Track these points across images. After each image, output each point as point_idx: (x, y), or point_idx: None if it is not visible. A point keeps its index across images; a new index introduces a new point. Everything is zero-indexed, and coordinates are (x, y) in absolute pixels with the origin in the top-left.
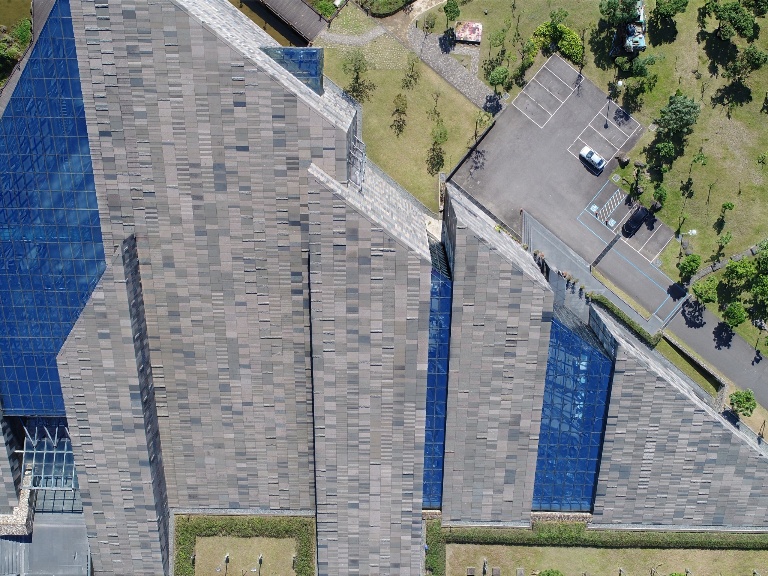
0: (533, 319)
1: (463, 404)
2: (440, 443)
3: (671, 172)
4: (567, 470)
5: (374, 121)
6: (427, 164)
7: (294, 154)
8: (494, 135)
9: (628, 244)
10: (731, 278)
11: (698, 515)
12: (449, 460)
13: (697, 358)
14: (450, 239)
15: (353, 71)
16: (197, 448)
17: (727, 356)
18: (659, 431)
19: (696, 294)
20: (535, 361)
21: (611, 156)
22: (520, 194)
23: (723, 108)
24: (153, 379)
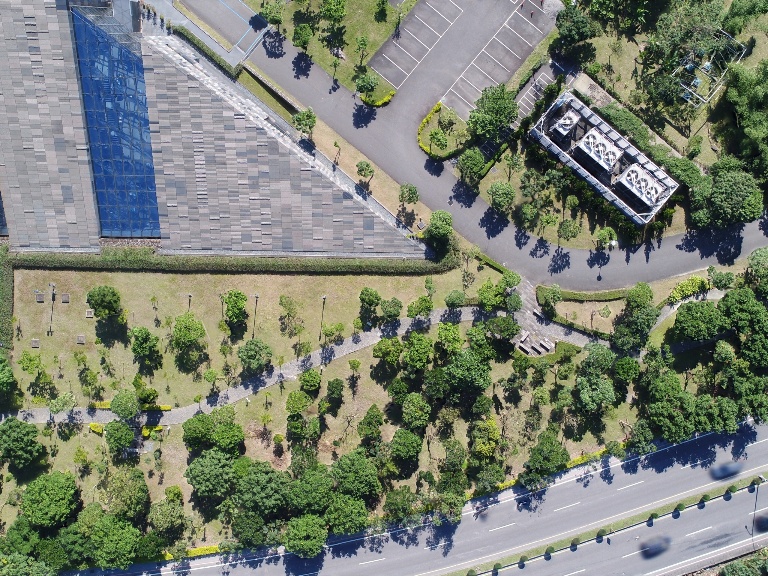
0: (48, 7)
1: (1, 108)
2: None
3: None
4: (128, 189)
5: None
6: None
7: None
8: None
9: None
10: (299, 0)
11: (266, 239)
12: (2, 175)
13: (276, 88)
14: None
15: None
16: None
17: (305, 85)
18: (204, 139)
19: (264, 16)
20: (61, 57)
21: None
22: None
23: None
24: None
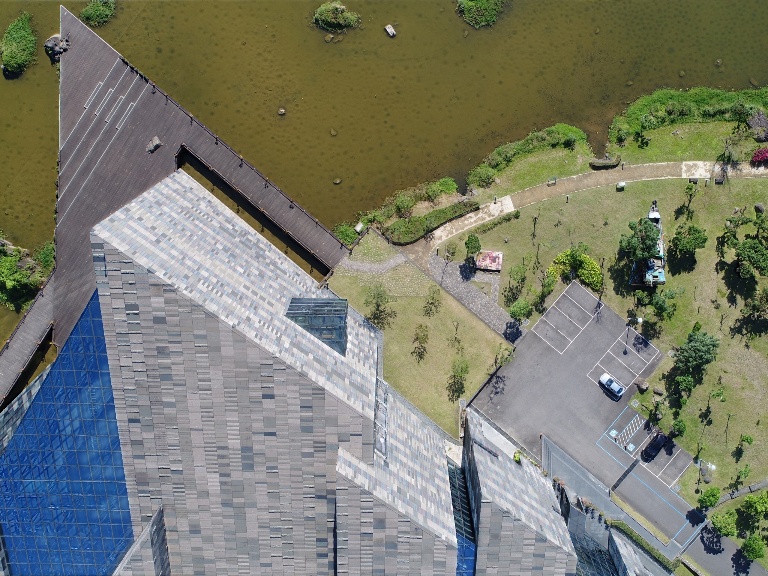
0: None
1: None
2: None
3: (690, 399)
4: None
5: (395, 348)
6: (448, 391)
7: (321, 439)
8: (514, 361)
9: (647, 469)
10: (750, 511)
11: None
12: None
13: None
14: (473, 490)
15: (375, 304)
16: None
17: None
18: None
19: (715, 527)
20: None
21: (630, 382)
22: (540, 419)
23: (742, 338)
24: None
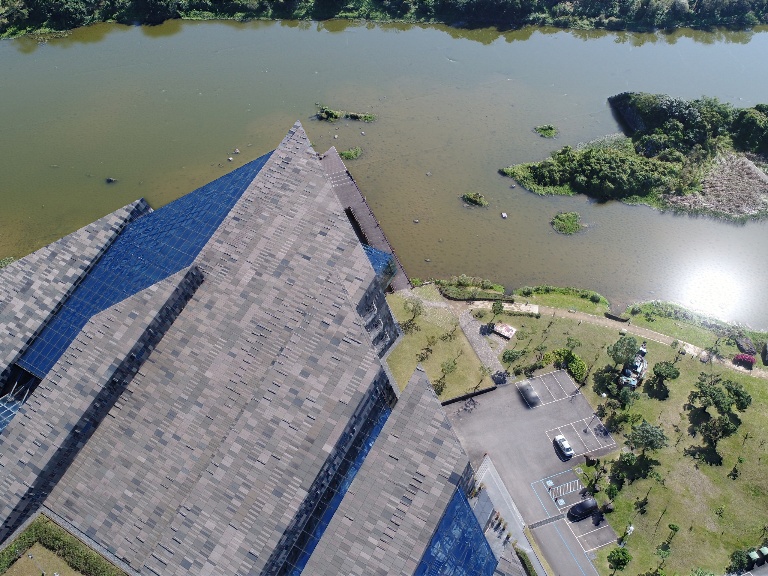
0: (441, 475)
1: (342, 531)
2: (300, 569)
3: (630, 486)
4: None
5: (407, 347)
6: None
7: None
8: (491, 396)
9: (569, 526)
10: None
11: None
12: None
13: None
14: None
15: (411, 310)
16: (111, 457)
17: None
18: None
19: None
20: (426, 519)
21: (581, 453)
22: (491, 443)
23: (693, 459)
24: (131, 382)
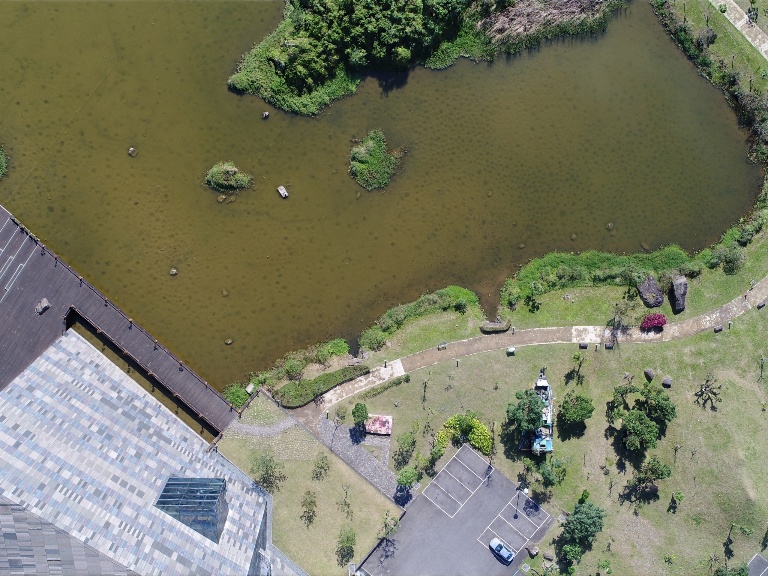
0: None
1: None
2: None
3: (580, 565)
4: None
5: (284, 512)
6: (337, 555)
7: None
8: (404, 524)
9: None
10: None
11: None
12: None
13: None
14: None
15: (261, 471)
16: None
17: None
18: None
19: None
20: None
21: (521, 546)
22: None
23: (630, 505)
24: None
